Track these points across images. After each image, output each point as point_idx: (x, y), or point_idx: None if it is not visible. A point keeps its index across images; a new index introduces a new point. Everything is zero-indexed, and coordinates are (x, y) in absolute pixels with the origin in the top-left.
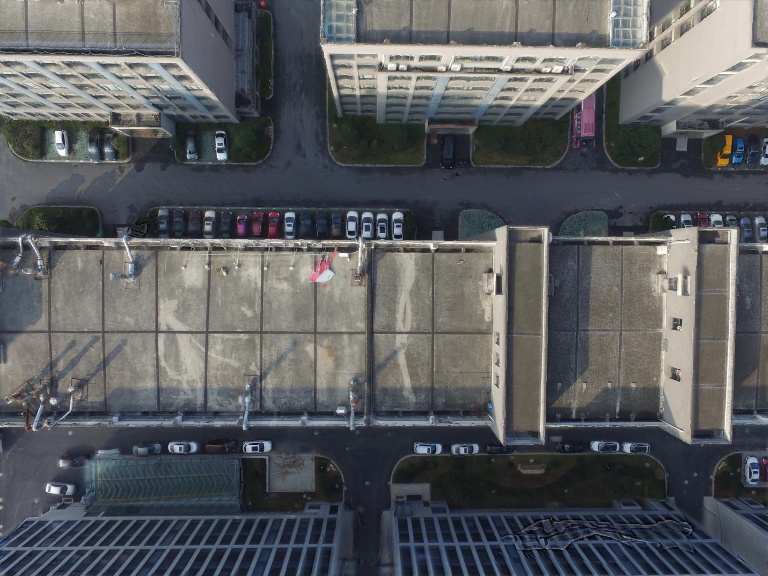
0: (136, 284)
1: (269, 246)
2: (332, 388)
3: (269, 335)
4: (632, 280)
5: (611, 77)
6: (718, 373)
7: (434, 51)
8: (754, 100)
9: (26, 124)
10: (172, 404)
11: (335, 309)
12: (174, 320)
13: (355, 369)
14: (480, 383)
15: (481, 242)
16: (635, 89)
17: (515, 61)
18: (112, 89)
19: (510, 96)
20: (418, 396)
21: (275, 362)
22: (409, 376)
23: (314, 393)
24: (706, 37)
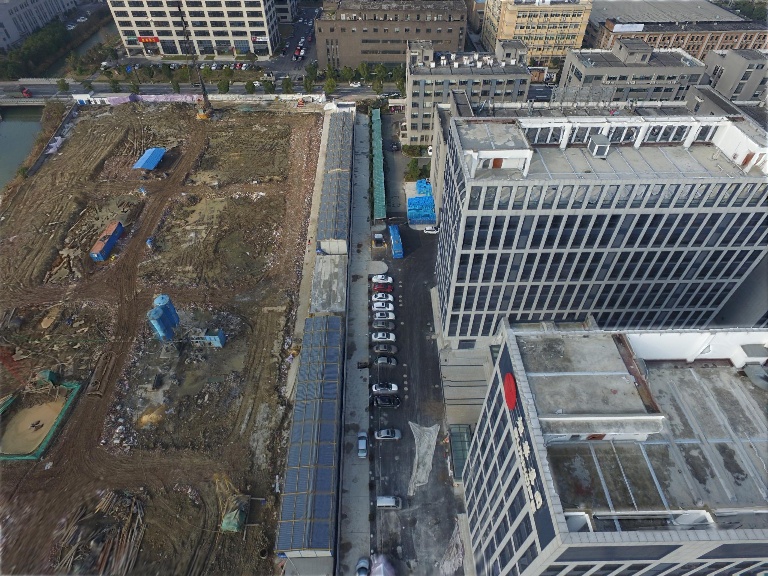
0: None
1: None
2: None
3: None
4: None
5: None
6: None
7: (626, 71)
8: None
9: (414, 146)
10: None
11: None
12: None
13: None
14: None
15: (680, 101)
16: None
17: (656, 78)
18: None
19: None
20: None
21: None
22: None
23: None
24: (726, 77)
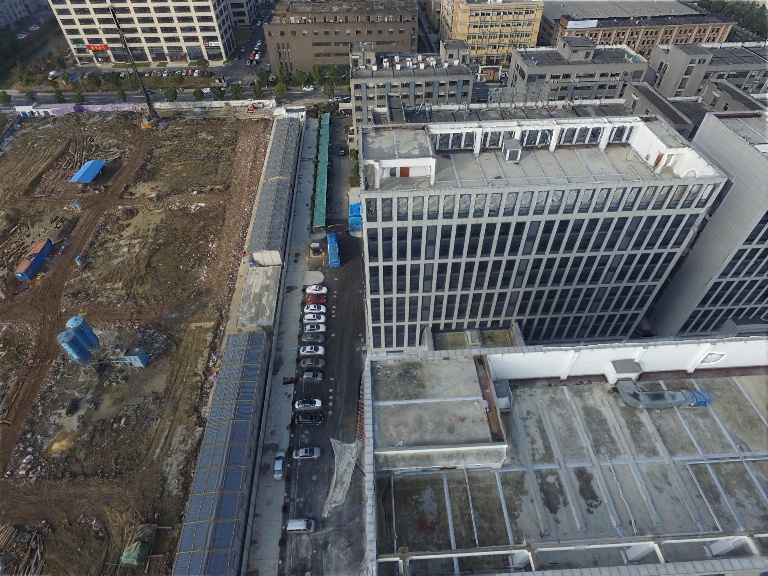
0: None
1: (524, 109)
2: None
3: None
4: (695, 108)
5: None
6: (758, 108)
7: (569, 69)
8: None
9: None
10: None
11: None
12: None
13: None
14: None
15: (619, 98)
16: None
17: None
18: None
19: None
20: None
21: None
22: None
23: None
24: (670, 73)
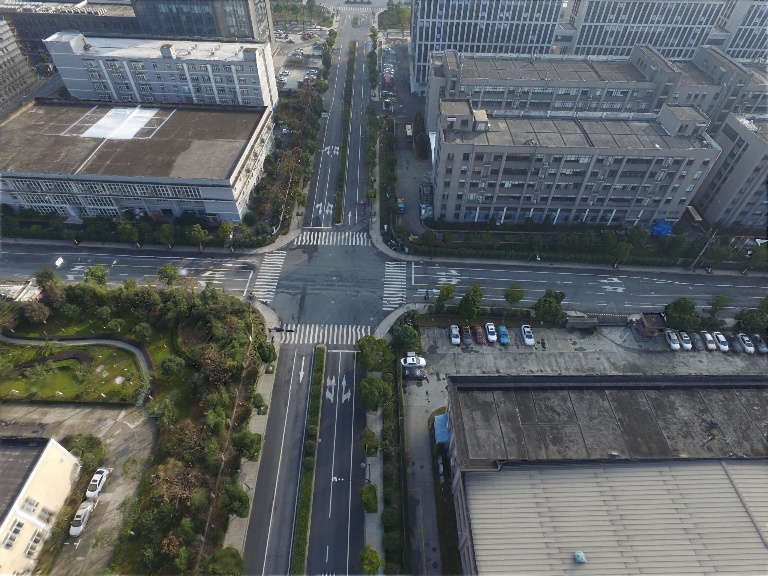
0: None
1: None
2: None
3: None
4: None
5: None
6: None
7: None
8: None
9: None
10: None
11: None
12: None
13: (767, 70)
14: None
15: None
16: None
17: None
18: None
19: None
20: None
21: None
22: None
23: None
24: None
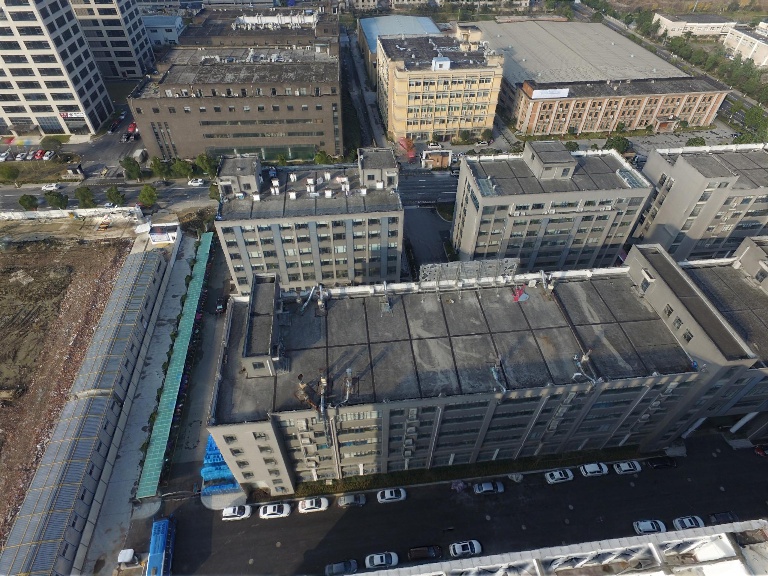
0: None
1: (478, 287)
2: (560, 365)
3: (497, 334)
4: (732, 283)
5: (637, 217)
6: None
7: (541, 198)
8: (725, 231)
9: None
10: (432, 390)
11: (539, 315)
12: (422, 331)
13: (572, 350)
14: (675, 351)
15: None
16: None
17: (584, 205)
18: (339, 252)
19: (581, 240)
20: (632, 365)
21: (508, 351)
22: (617, 352)
23: (547, 371)
24: (677, 194)
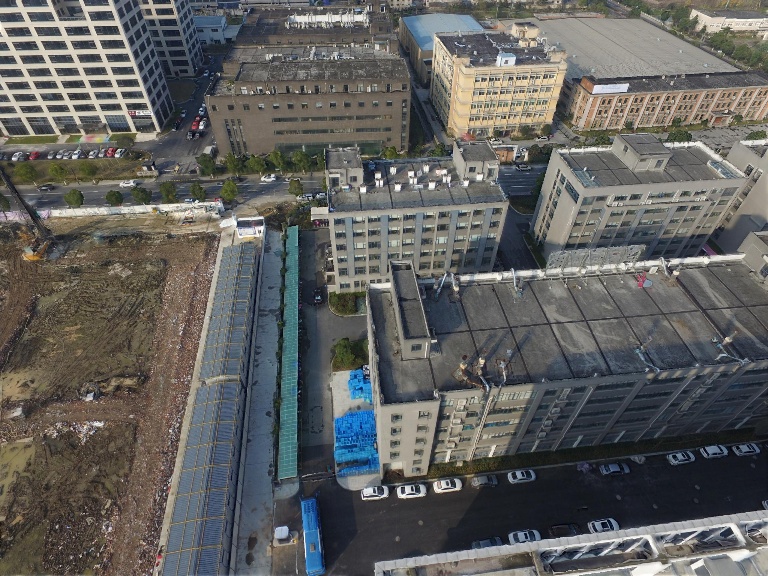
0: (522, 299)
1: (599, 274)
2: (701, 348)
3: (631, 318)
4: None
5: None
6: None
7: (640, 189)
8: None
9: (345, 295)
10: (583, 371)
11: (667, 300)
12: (558, 316)
13: (708, 333)
14: None
15: (735, 254)
16: (731, 237)
17: (680, 195)
18: (440, 243)
19: (672, 230)
20: None
21: (646, 334)
22: (752, 334)
23: (689, 352)
24: (766, 184)
